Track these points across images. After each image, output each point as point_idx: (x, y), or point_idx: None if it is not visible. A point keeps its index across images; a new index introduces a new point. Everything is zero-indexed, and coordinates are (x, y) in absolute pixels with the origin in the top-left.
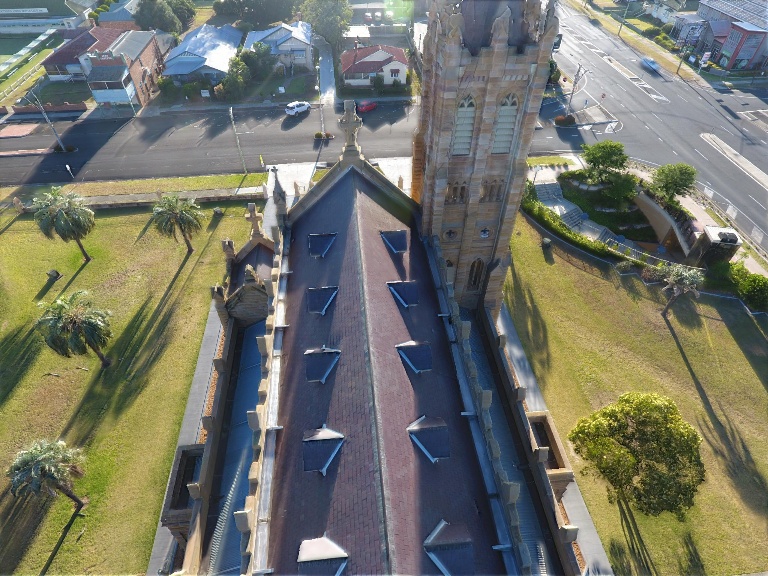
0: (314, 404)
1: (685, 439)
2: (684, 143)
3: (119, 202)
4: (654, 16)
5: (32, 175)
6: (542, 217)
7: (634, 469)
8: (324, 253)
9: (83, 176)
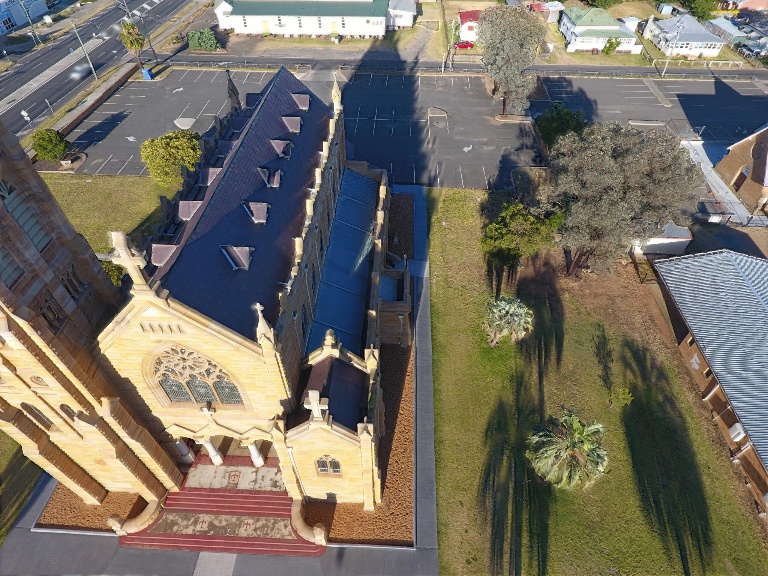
0: (283, 171)
1: None
2: None
3: None
4: None
5: None
6: None
7: None
8: None
9: None
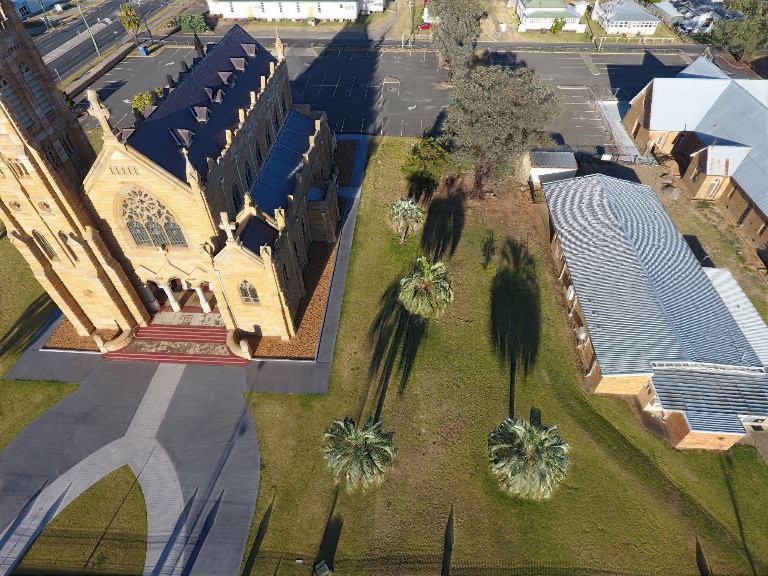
0: None
1: None
2: None
3: None
4: None
5: None
6: None
7: None
8: None
9: None
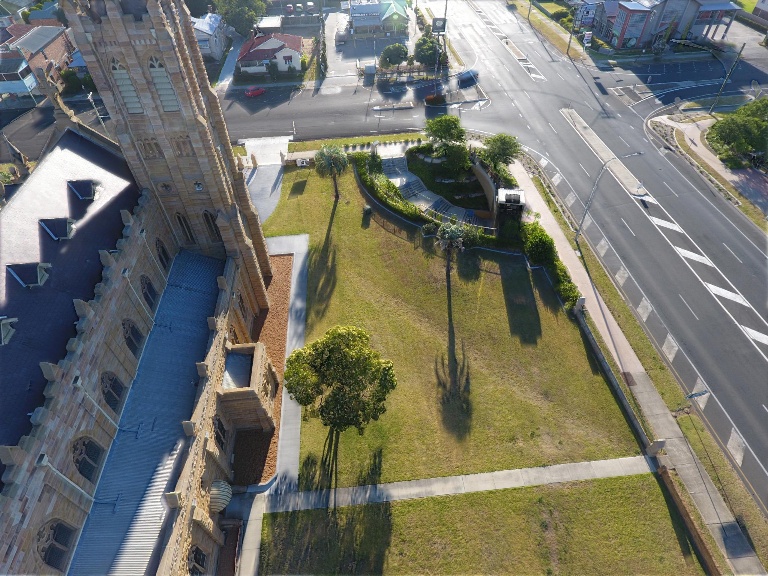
0: None
1: (353, 361)
2: (541, 118)
3: None
4: None
5: None
6: (372, 187)
7: (318, 389)
8: None
9: None
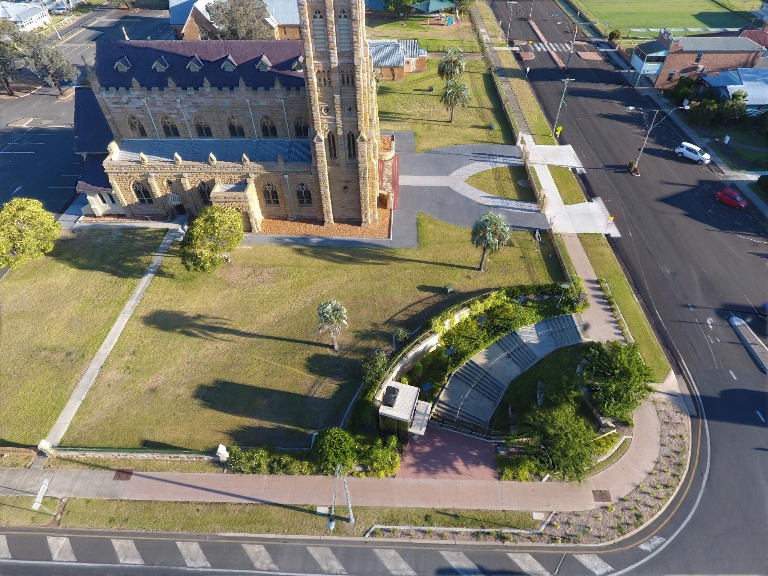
0: None
1: None
2: None
3: None
4: None
5: (534, 70)
6: None
7: None
8: None
9: (536, 83)
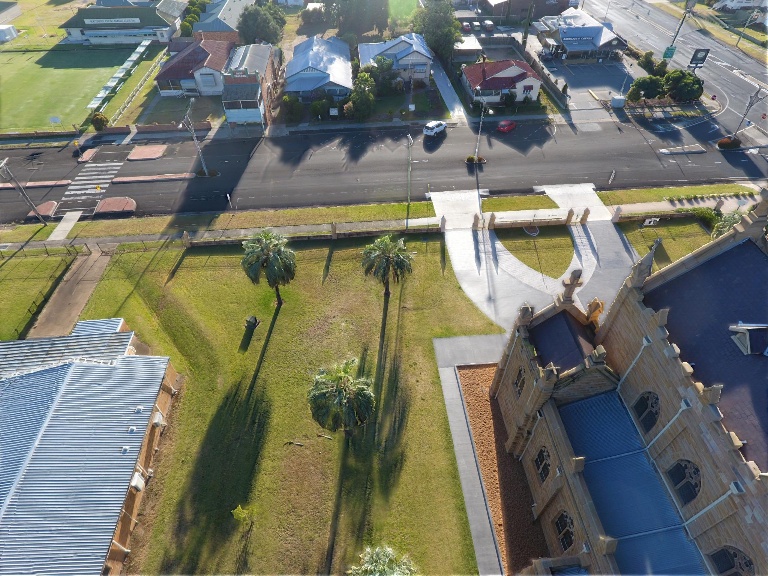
0: None
1: None
2: None
3: (288, 235)
4: (767, 25)
5: (182, 203)
6: None
7: None
8: (766, 350)
9: (236, 204)
